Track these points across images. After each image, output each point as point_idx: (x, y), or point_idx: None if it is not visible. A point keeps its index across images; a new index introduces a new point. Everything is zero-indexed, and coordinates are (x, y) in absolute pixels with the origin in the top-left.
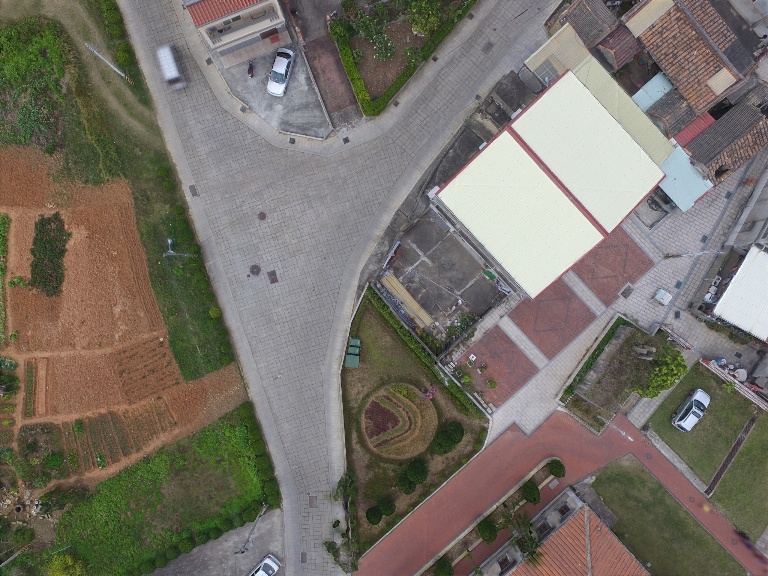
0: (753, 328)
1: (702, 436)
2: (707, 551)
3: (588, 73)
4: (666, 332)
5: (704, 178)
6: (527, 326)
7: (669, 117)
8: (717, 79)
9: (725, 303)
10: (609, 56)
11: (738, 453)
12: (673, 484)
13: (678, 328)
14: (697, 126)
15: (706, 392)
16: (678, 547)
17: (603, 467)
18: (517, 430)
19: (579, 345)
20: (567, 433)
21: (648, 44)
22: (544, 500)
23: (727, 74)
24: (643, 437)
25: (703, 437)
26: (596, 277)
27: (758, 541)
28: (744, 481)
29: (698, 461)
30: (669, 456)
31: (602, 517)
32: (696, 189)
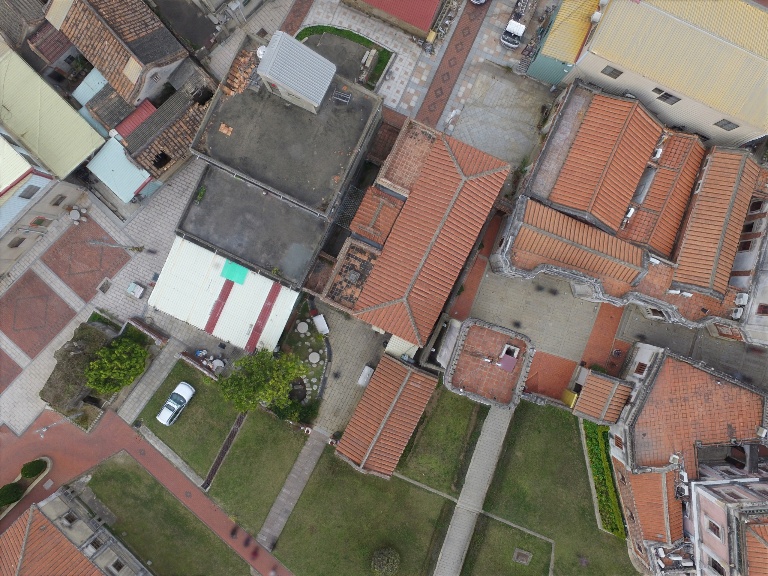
0: (189, 318)
1: (195, 429)
2: (210, 546)
3: (7, 68)
4: (133, 325)
5: (139, 168)
6: (6, 325)
7: (96, 108)
8: (129, 68)
9: (158, 293)
10: (32, 50)
11: (232, 445)
12: (168, 479)
13: (159, 321)
14: (139, 116)
15: (192, 384)
16: (180, 543)
17: (97, 465)
18: (7, 431)
19: (61, 342)
20: (58, 432)
21: (70, 36)
22: (39, 501)
23: (135, 62)
24: (135, 433)
25: (196, 430)
26: (73, 273)
27: (259, 534)
28: (240, 473)
29: (193, 455)
30: (163, 451)
31: (98, 516)
32: (134, 180)
